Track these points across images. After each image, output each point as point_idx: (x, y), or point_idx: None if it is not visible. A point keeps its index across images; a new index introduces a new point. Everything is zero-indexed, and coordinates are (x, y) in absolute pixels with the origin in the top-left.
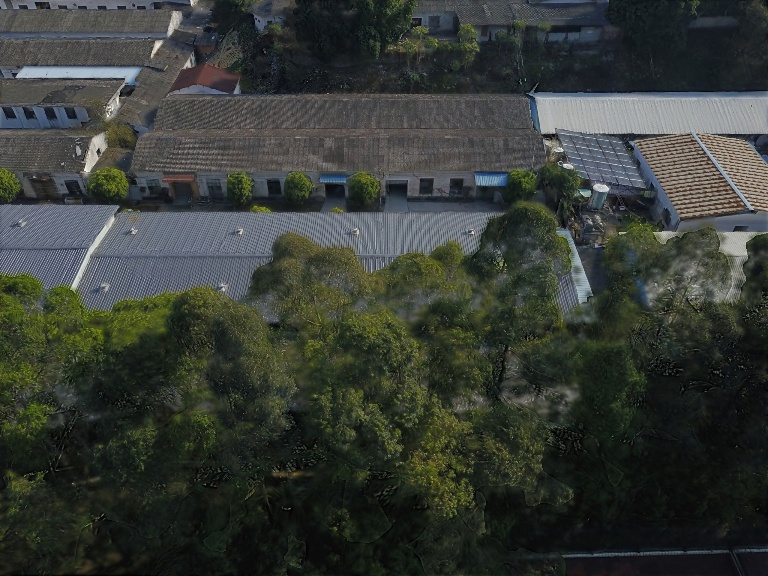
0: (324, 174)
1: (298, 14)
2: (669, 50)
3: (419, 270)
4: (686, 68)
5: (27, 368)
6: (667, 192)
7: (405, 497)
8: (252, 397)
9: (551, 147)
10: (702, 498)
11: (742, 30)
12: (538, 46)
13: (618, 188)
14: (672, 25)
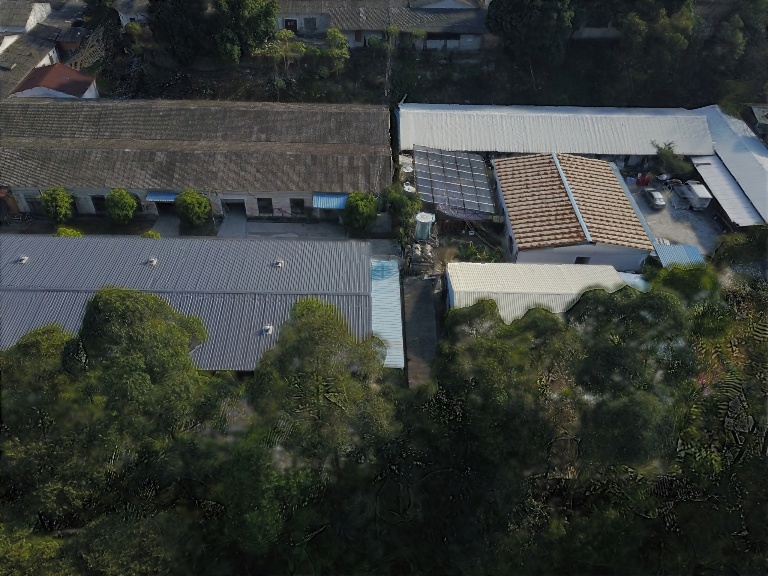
0: (151, 191)
1: None
2: (549, 62)
3: (37, 352)
4: (568, 81)
5: None
6: (511, 218)
7: None
8: None
9: (401, 166)
10: (458, 574)
11: (621, 43)
12: (416, 53)
13: (465, 212)
14: (548, 36)
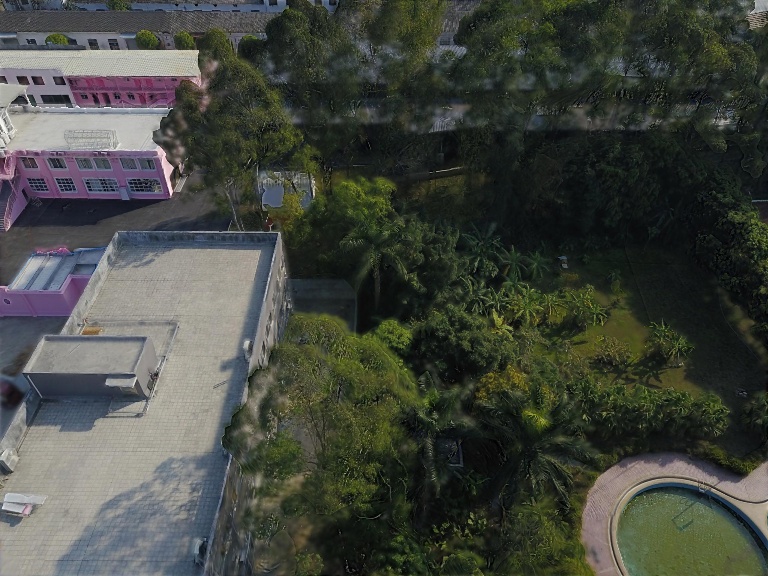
0: None
1: None
2: None
3: None
4: None
5: (550, 5)
6: None
7: (665, 127)
8: (656, 8)
9: None
10: None
11: None
12: None
13: None
14: None
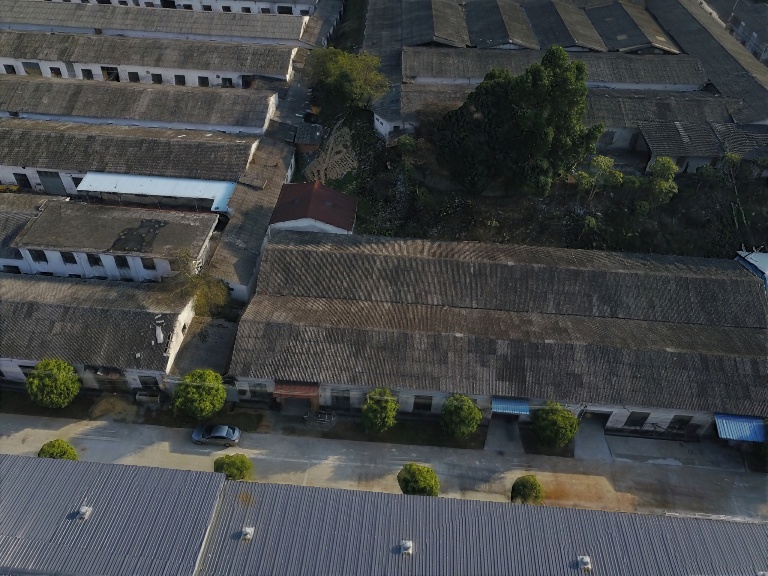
0: (498, 398)
1: (435, 122)
2: None
3: None
4: None
5: None
6: None
7: None
8: None
9: None
10: None
11: None
12: (748, 183)
13: None
14: None
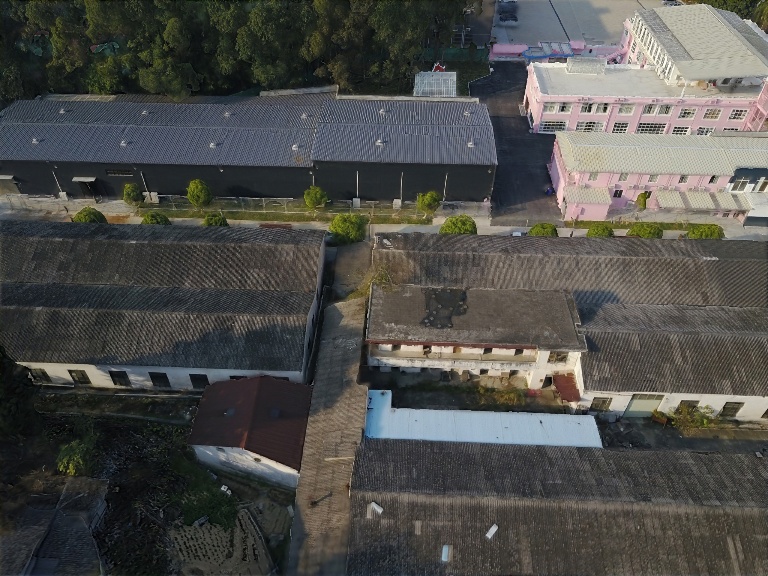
0: None
1: None
2: None
3: None
4: None
5: None
6: None
7: None
8: None
9: None
10: None
11: None
12: None
13: None
14: None
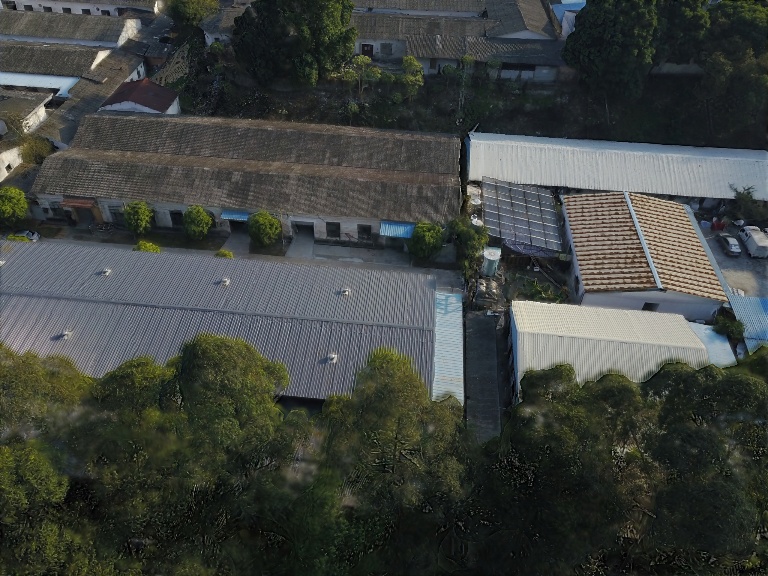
0: (226, 210)
1: None
2: (625, 97)
3: (133, 384)
4: (644, 116)
5: None
6: (579, 258)
7: None
8: None
9: (469, 198)
10: None
11: (703, 82)
12: (489, 83)
13: (531, 248)
14: (627, 72)
